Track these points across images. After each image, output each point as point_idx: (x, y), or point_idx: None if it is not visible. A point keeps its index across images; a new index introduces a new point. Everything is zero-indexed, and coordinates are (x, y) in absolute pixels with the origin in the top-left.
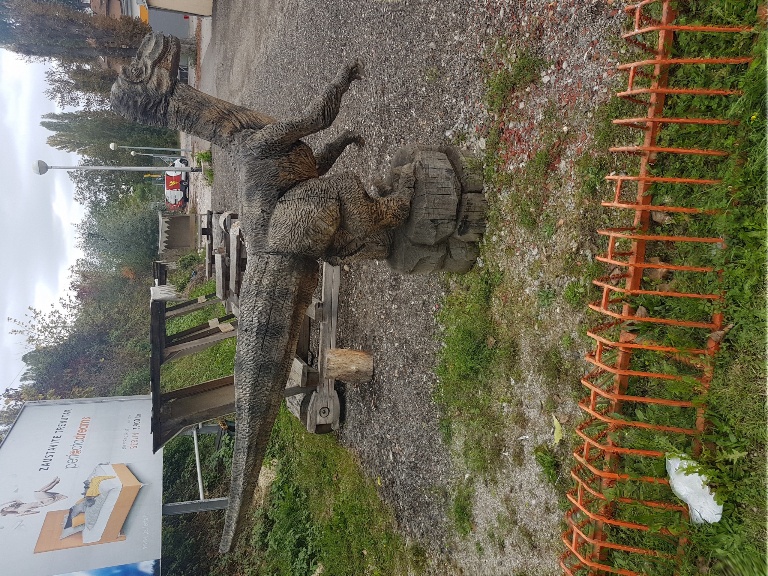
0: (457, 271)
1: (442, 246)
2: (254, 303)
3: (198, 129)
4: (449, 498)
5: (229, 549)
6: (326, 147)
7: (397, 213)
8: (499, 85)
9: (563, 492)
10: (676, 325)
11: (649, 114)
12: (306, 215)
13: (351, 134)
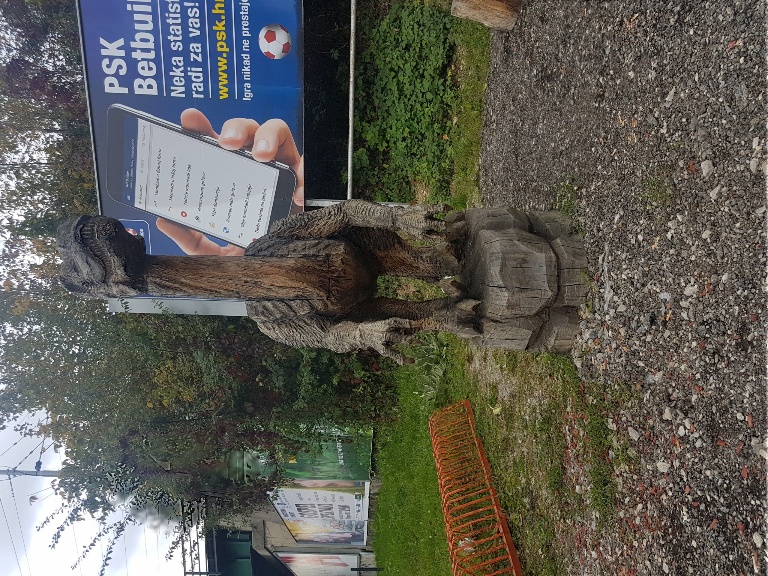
0: None
1: None
2: None
3: None
4: None
5: None
6: None
7: None
8: (594, 434)
9: None
10: None
11: None
12: None
13: None
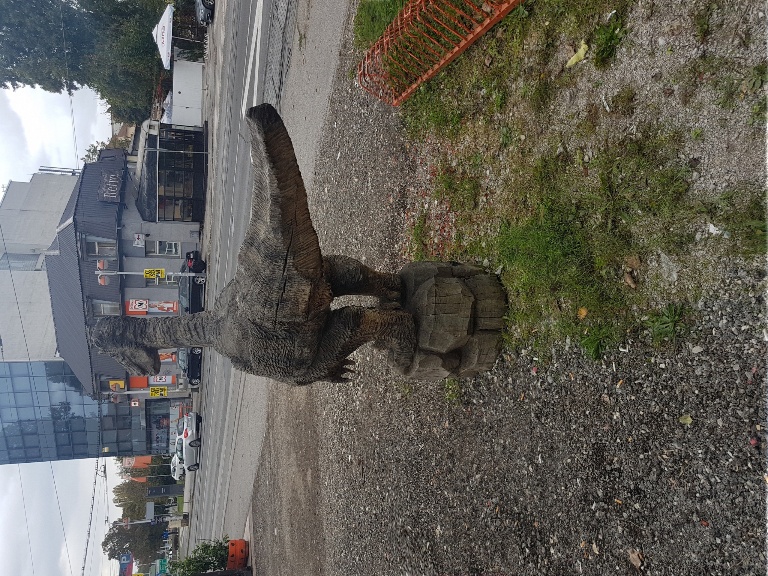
0: (495, 298)
1: None
2: None
3: None
4: None
5: None
6: None
7: None
8: (418, 259)
9: (624, 1)
10: None
11: (430, 73)
12: None
13: None
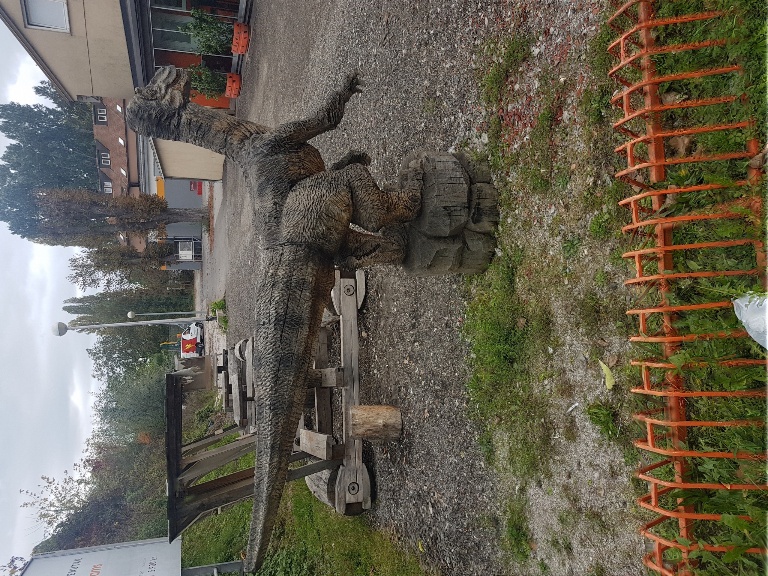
0: (476, 268)
1: (458, 240)
2: (271, 294)
3: (210, 139)
4: (501, 526)
5: (254, 567)
6: (334, 165)
7: (409, 204)
8: (493, 78)
9: (628, 443)
10: (710, 161)
11: (639, 12)
12: (318, 199)
13: (357, 152)
